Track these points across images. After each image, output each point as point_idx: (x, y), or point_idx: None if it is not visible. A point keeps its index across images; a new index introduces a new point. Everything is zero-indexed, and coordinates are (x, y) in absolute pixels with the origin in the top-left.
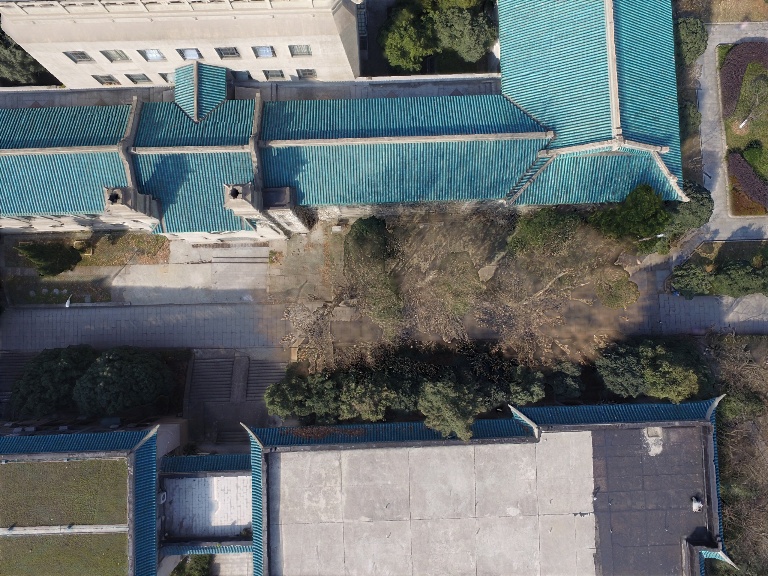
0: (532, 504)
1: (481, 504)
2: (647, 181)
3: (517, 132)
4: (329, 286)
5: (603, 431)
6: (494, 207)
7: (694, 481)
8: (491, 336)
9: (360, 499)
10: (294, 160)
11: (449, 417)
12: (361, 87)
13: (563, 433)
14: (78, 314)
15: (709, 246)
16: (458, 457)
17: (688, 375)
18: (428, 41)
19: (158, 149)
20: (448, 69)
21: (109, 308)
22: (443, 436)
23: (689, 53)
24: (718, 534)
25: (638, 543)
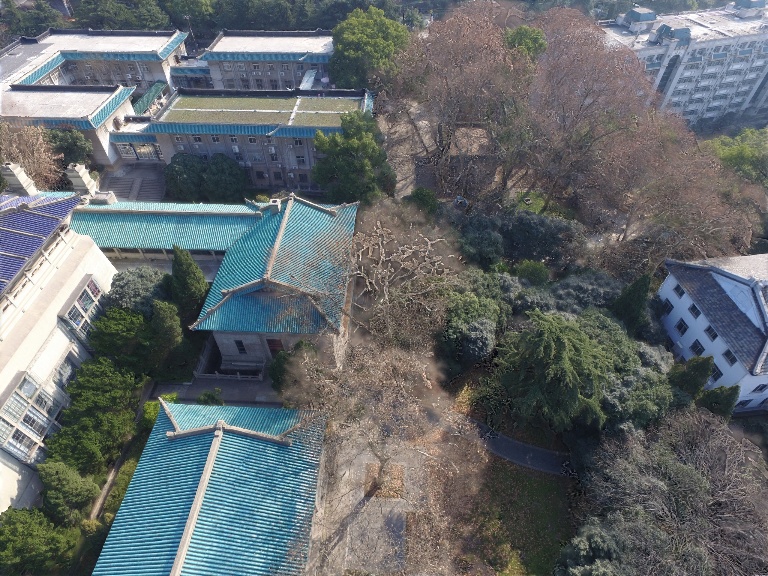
0: None
1: None
2: None
3: None
4: None
5: None
6: None
7: None
8: None
9: None
10: None
11: None
12: None
13: None
14: None
15: None
16: None
17: None
18: None
19: None
20: None
21: None
22: None
23: None
24: None
25: None
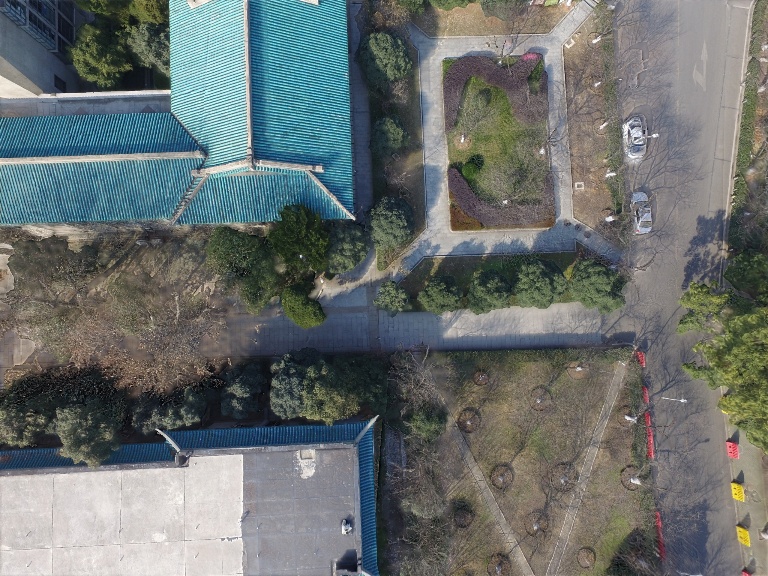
0: (178, 529)
1: (126, 530)
2: (311, 200)
3: (170, 151)
4: None
5: (255, 454)
6: (208, 224)
7: (346, 503)
8: (210, 354)
9: (1, 527)
10: None
11: (65, 444)
12: (49, 104)
13: (214, 457)
14: None
15: (429, 261)
16: (104, 483)
17: (333, 397)
18: (122, 56)
19: None
20: (165, 84)
21: None
22: (74, 463)
23: (388, 69)
24: (360, 557)
25: (287, 567)
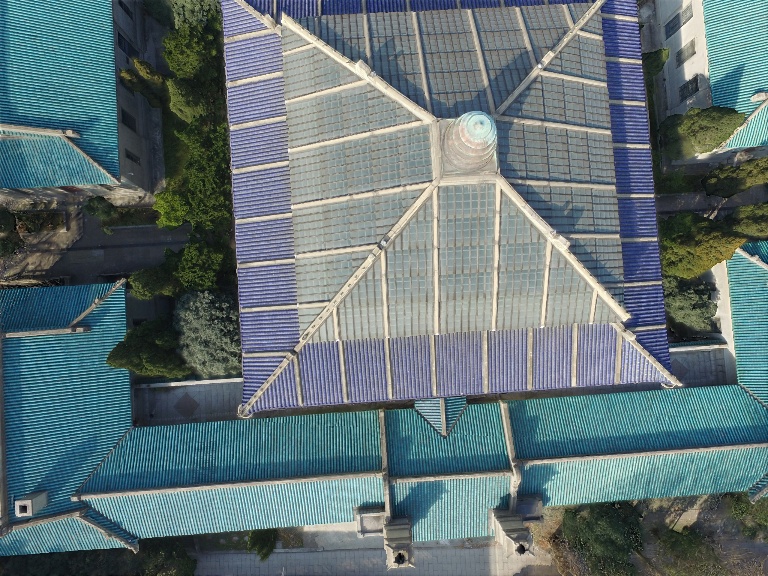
0: None
1: None
2: None
3: (767, 436)
4: (551, 557)
5: None
6: None
7: None
8: None
9: None
10: (545, 472)
11: None
12: None
13: None
14: (268, 559)
15: None
16: None
17: None
18: None
19: (419, 480)
20: None
21: (301, 553)
22: None
23: None
24: None
25: None
